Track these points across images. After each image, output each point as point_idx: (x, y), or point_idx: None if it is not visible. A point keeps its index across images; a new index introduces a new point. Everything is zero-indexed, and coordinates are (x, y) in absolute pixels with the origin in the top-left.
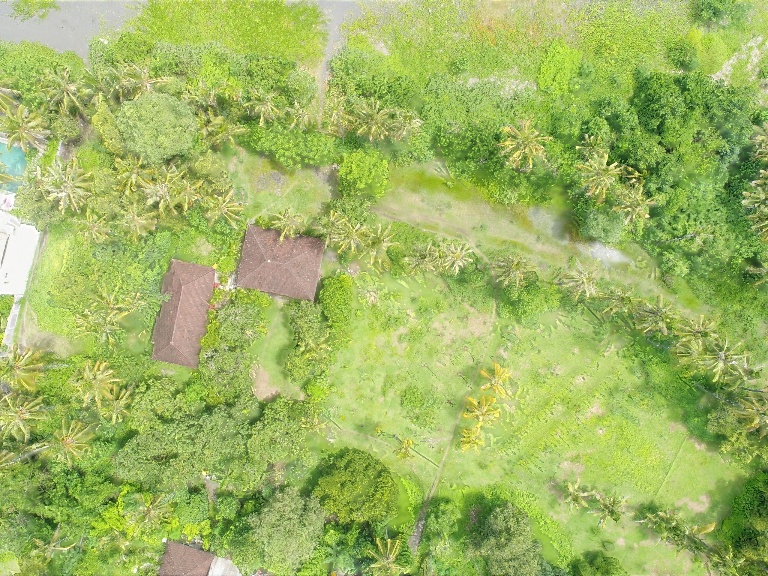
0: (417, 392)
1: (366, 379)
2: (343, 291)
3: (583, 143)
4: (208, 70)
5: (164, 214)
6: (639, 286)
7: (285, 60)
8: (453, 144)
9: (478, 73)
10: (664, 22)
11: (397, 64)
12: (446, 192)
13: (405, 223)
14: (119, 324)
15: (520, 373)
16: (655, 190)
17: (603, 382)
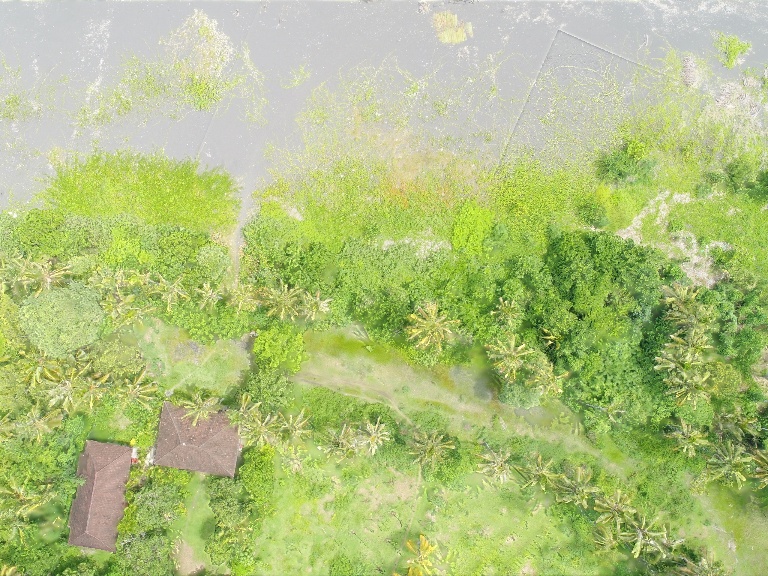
0: (345, 561)
1: (293, 549)
2: (263, 467)
3: (498, 307)
4: (119, 244)
5: (69, 412)
6: (563, 442)
7: (197, 232)
8: (368, 314)
9: (392, 235)
10: (573, 180)
11: (311, 230)
12: (366, 355)
13: (326, 388)
14: (30, 516)
15: (449, 536)
16: (570, 355)
17: (533, 541)
